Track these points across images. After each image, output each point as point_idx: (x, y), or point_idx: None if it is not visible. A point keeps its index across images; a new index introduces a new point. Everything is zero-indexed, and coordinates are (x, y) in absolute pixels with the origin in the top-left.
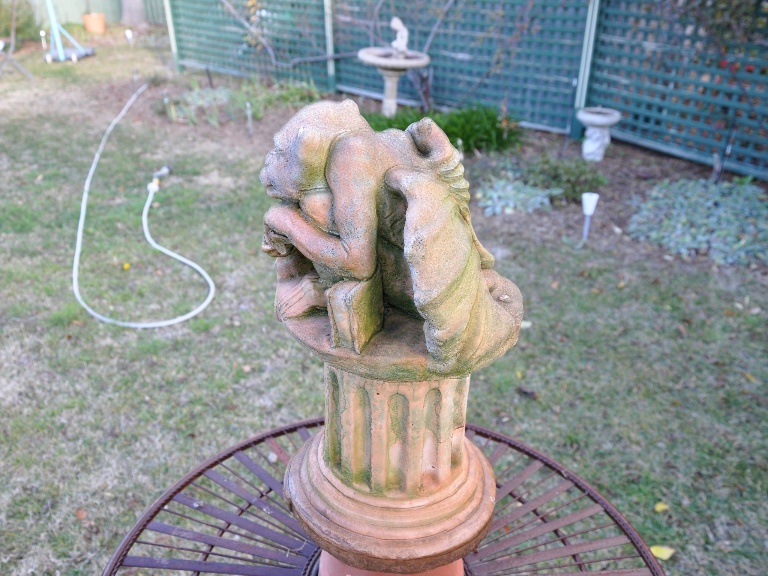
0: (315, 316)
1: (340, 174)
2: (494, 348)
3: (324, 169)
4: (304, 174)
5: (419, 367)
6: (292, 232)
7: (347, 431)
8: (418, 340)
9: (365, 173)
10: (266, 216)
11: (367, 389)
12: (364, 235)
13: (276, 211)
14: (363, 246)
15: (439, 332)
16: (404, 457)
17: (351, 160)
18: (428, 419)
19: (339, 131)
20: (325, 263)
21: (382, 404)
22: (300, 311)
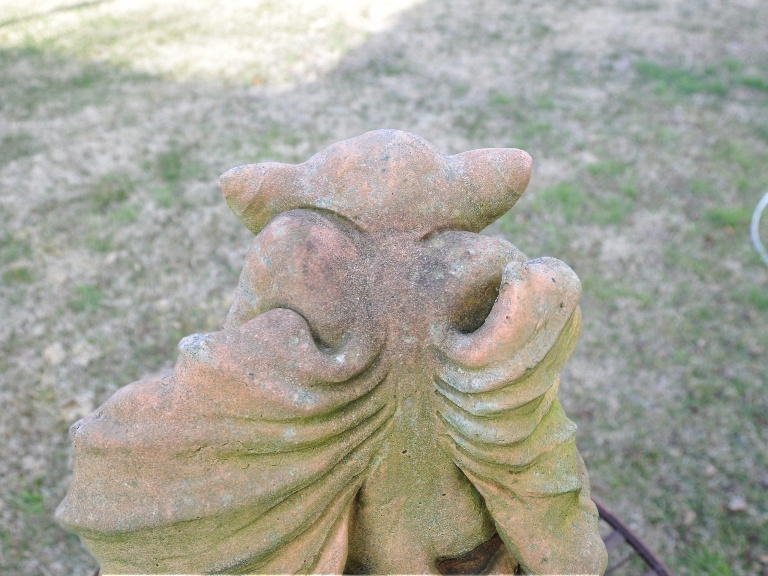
0: None
1: None
2: None
3: None
4: None
5: None
6: None
7: None
8: None
9: (252, 286)
10: None
11: None
12: None
13: None
14: None
15: None
16: None
17: (250, 255)
18: None
19: (317, 202)
20: None
21: None
22: None
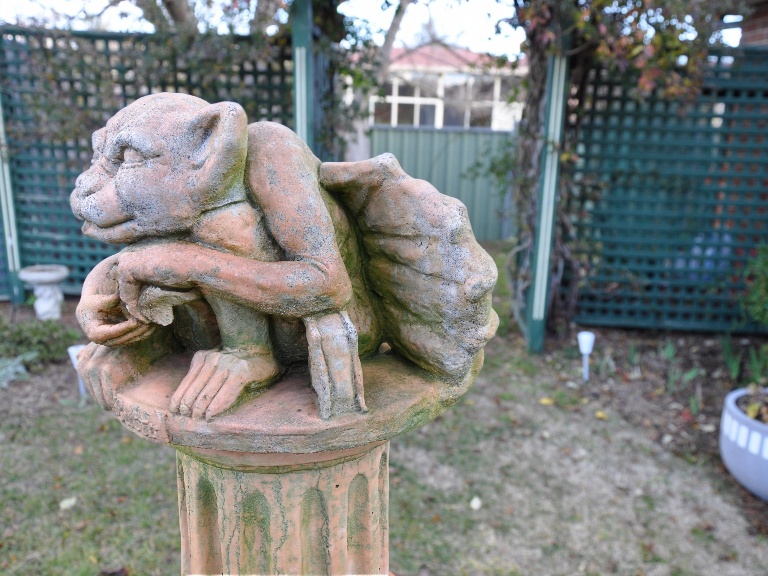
0: (246, 402)
1: (281, 171)
2: None
3: (244, 171)
4: (225, 178)
5: (433, 400)
6: (221, 268)
7: (291, 573)
8: (399, 377)
9: (307, 168)
10: (144, 264)
11: (322, 487)
12: (334, 246)
13: (164, 251)
14: (339, 260)
15: (484, 328)
16: (361, 569)
17: (290, 151)
18: None
19: None
20: (294, 297)
21: (343, 499)
22: (234, 397)
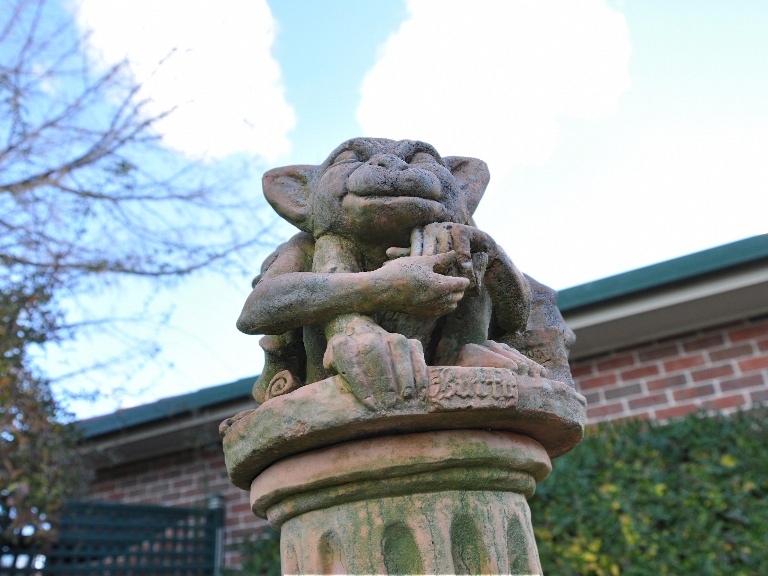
0: None
1: None
2: None
3: None
4: None
5: None
6: None
7: None
8: None
9: None
10: None
11: None
12: None
13: None
14: None
15: None
16: None
17: None
18: None
19: None
20: None
21: None
22: None
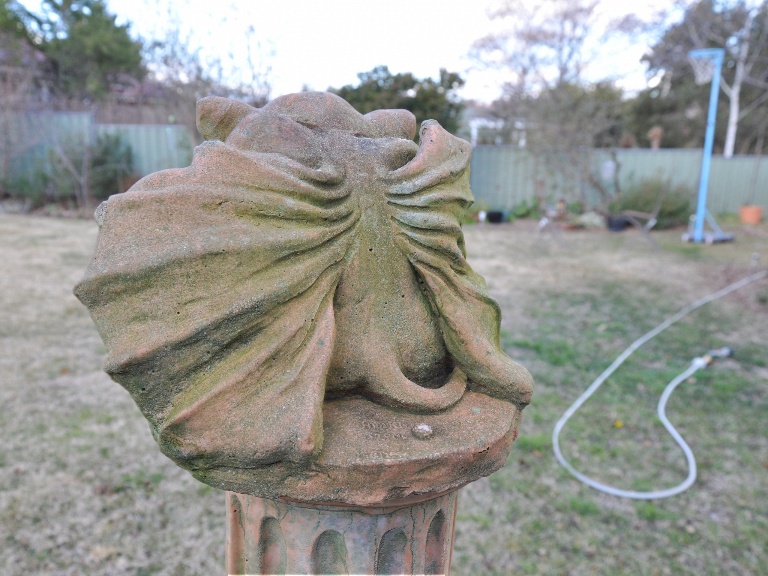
0: None
1: None
2: (240, 453)
3: None
4: None
5: None
6: None
7: None
8: None
9: None
10: None
11: None
12: None
13: None
14: None
15: None
16: None
17: (229, 138)
18: (283, 572)
19: None
20: None
21: None
22: None
